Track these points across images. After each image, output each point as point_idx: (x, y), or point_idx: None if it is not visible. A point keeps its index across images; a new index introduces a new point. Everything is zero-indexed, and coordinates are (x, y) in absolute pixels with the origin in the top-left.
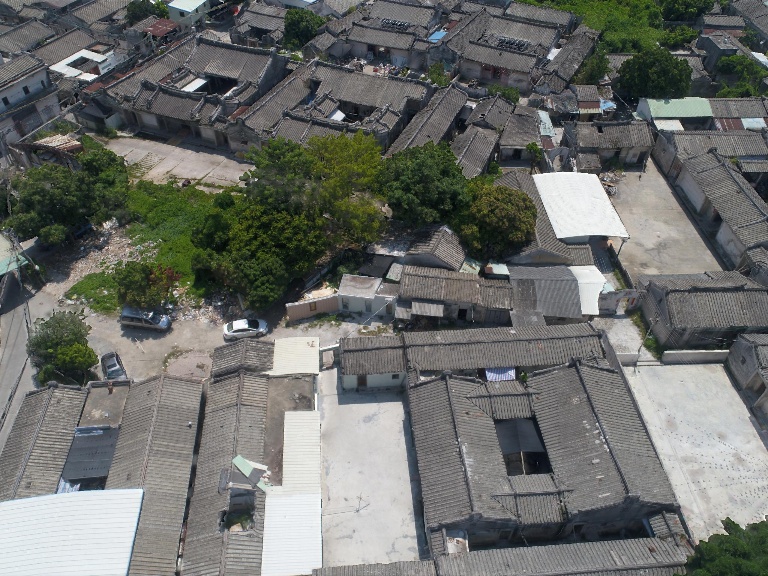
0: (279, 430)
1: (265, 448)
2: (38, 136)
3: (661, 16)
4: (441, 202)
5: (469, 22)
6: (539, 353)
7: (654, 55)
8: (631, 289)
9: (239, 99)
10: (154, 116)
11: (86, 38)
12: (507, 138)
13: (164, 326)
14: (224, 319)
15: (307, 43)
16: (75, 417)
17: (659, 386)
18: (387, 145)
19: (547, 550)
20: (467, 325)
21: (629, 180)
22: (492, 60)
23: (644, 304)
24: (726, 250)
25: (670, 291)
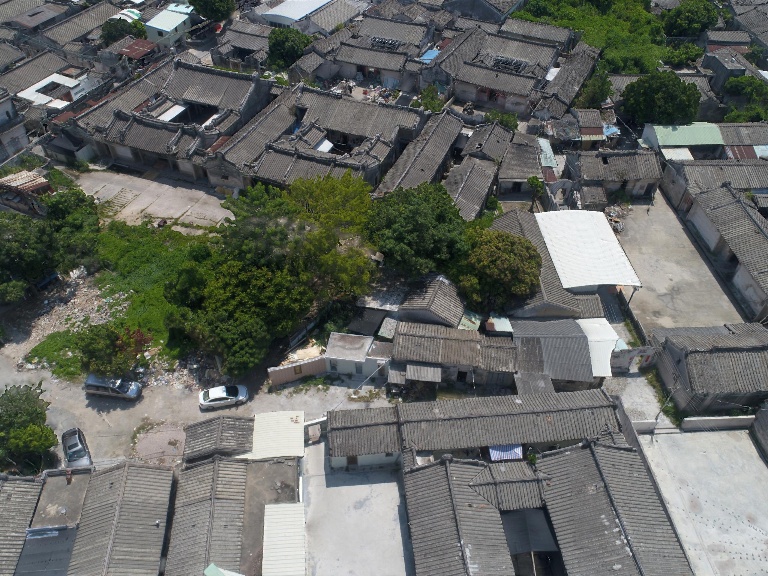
0: (258, 528)
1: (242, 552)
2: (2, 172)
3: (663, 31)
4: (437, 250)
5: (463, 40)
6: (548, 427)
7: (661, 79)
8: (646, 347)
9: (219, 129)
10: (128, 148)
11: (58, 61)
12: (506, 170)
13: (133, 395)
14: (200, 384)
15: (293, 64)
16: (27, 516)
17: (679, 458)
18: (378, 178)
19: None
20: (467, 388)
21: (637, 214)
22: (488, 82)
23: (660, 362)
24: (744, 295)
25: (690, 352)
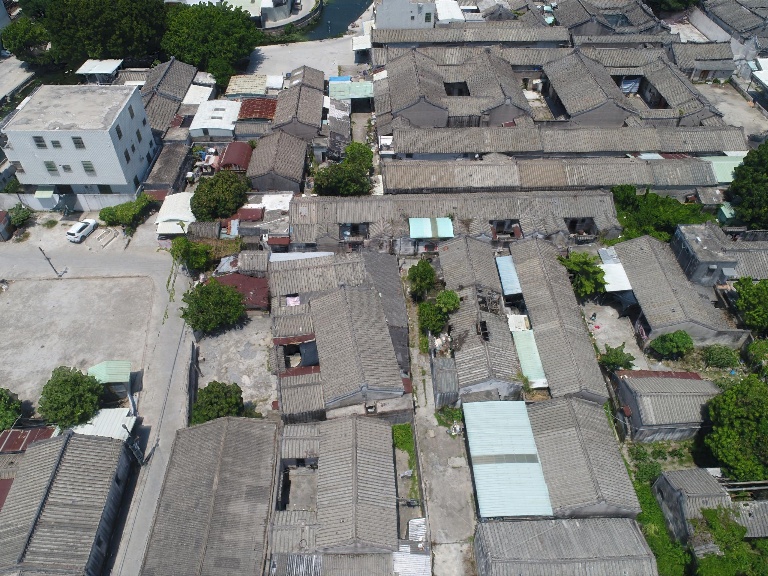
0: None
1: None
2: None
3: None
4: None
5: None
6: None
7: None
8: None
9: None
10: None
11: None
12: None
13: None
14: None
15: None
16: None
17: None
18: None
19: (751, 6)
20: None
21: None
22: None
23: None
24: None
25: (727, 42)
